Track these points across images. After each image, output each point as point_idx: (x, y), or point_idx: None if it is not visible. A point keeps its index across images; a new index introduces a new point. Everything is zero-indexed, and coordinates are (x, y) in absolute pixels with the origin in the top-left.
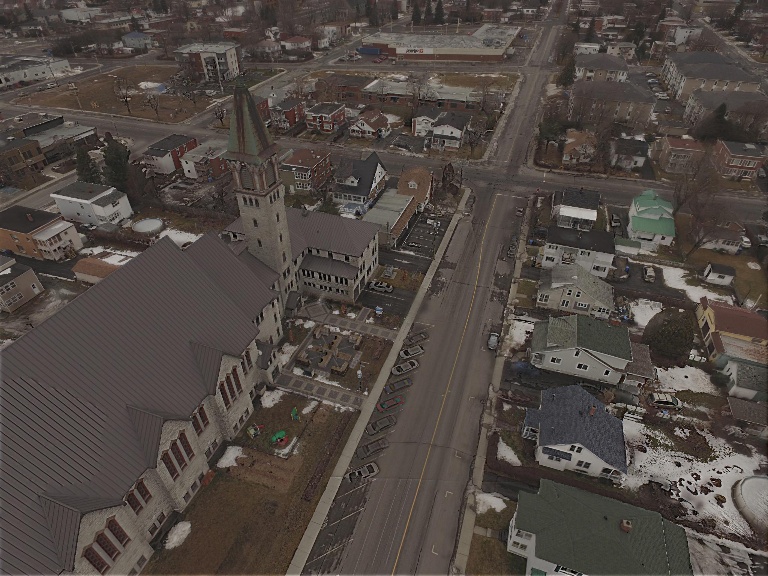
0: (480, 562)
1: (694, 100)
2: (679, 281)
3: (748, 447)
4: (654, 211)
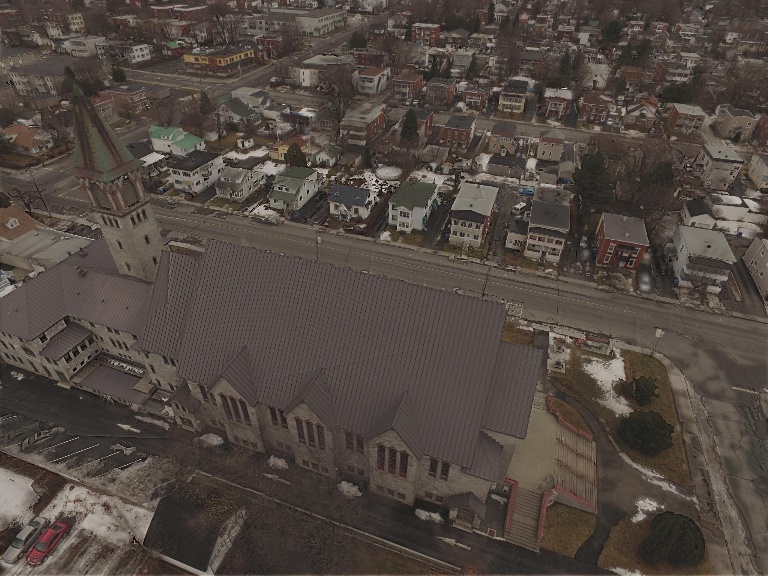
0: (415, 241)
1: (23, 76)
2: (242, 155)
3: (360, 171)
4: (178, 133)
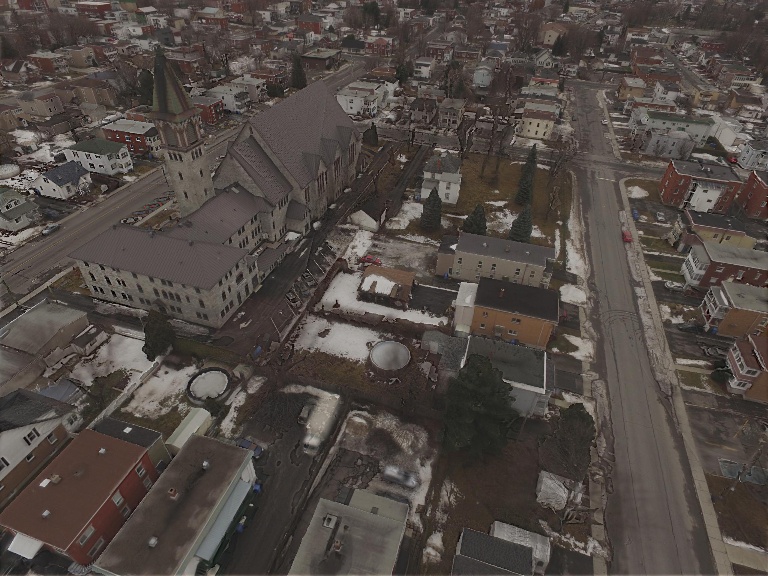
0: None
1: None
2: None
3: None
4: None
